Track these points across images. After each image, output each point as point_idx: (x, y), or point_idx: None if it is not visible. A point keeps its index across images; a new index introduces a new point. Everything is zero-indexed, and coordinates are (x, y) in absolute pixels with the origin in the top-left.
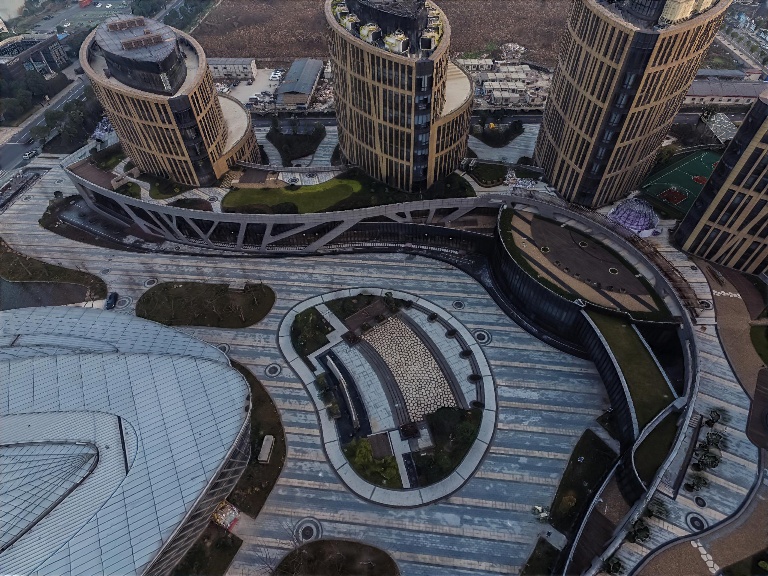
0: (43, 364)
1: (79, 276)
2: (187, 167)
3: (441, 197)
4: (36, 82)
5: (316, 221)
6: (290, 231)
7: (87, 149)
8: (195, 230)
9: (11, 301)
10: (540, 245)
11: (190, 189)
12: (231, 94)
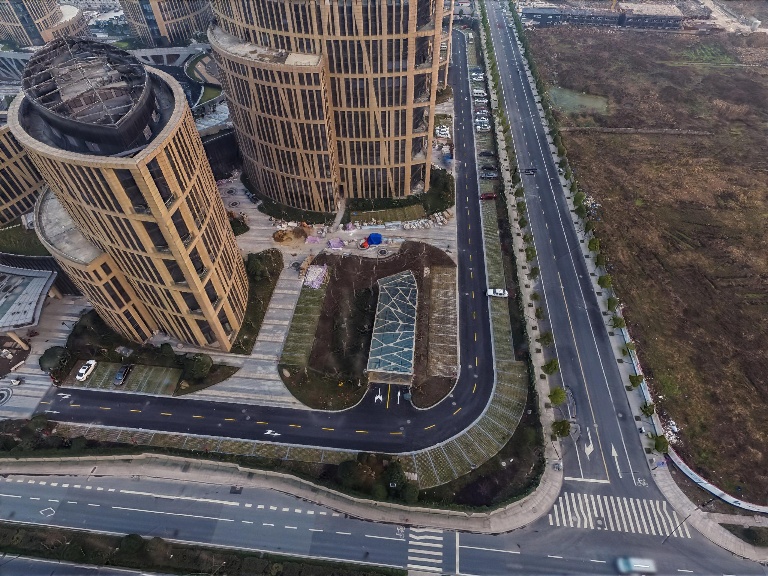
0: None
1: None
2: (22, 32)
3: (167, 47)
4: None
5: None
6: None
7: None
8: None
9: None
10: (208, 66)
11: (26, 47)
12: (100, 17)
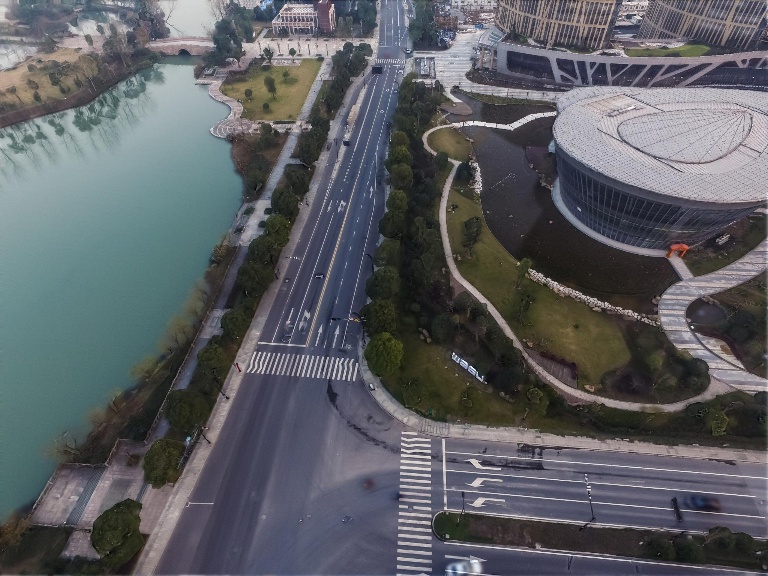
0: (669, 90)
1: (539, 101)
2: (601, 34)
3: None
4: (373, 8)
5: (697, 63)
6: (675, 71)
7: (487, 36)
8: (607, 74)
9: (509, 112)
10: None
11: (597, 50)
12: None
